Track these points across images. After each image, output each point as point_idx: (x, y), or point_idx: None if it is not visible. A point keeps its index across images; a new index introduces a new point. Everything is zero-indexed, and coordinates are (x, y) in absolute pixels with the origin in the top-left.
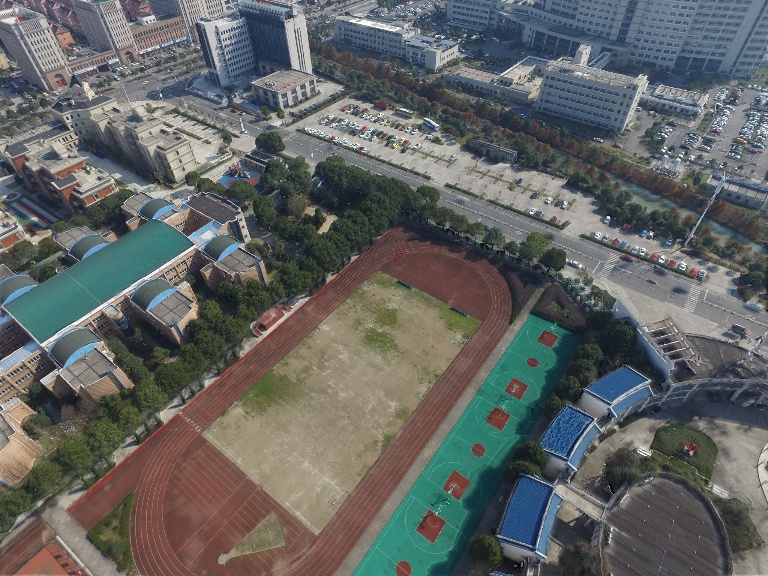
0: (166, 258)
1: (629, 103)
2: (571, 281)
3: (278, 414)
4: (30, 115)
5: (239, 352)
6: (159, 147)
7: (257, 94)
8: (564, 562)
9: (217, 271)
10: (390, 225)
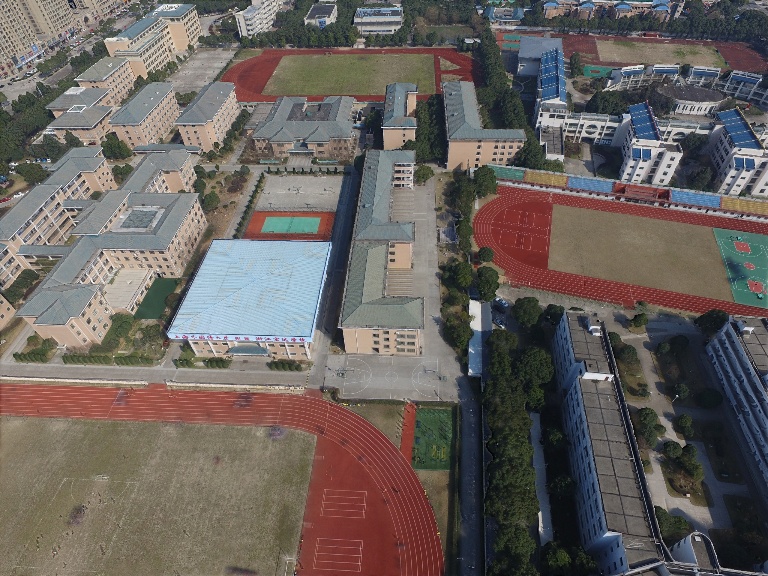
0: (638, 0)
1: None
2: None
3: (621, 47)
4: None
5: (629, 36)
6: None
7: None
8: None
9: (650, 13)
10: (747, 41)
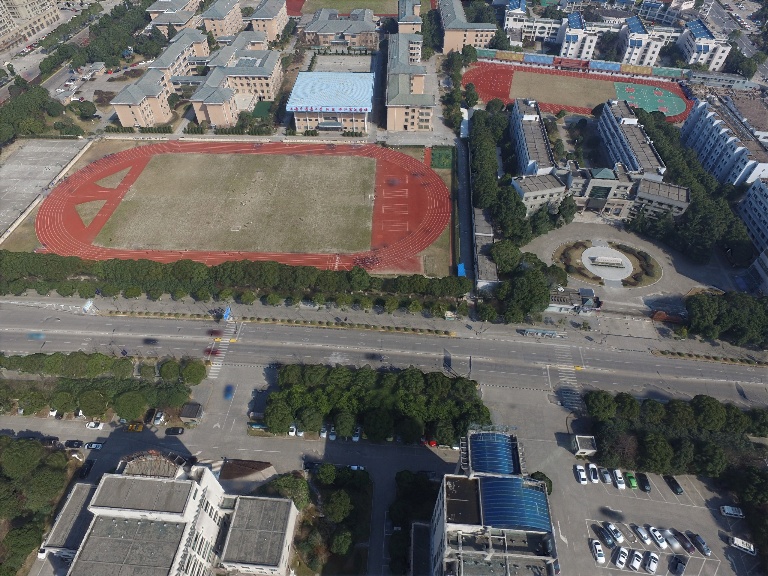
0: None
1: None
2: None
3: None
4: None
5: None
6: None
7: None
8: None
9: None
10: None
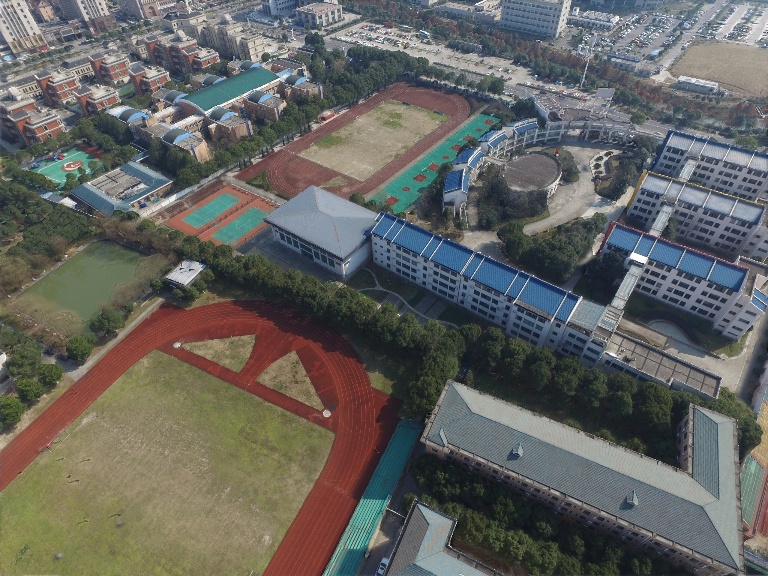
0: (264, 82)
1: (559, 15)
2: (507, 101)
3: (337, 148)
4: (137, 32)
5: (311, 129)
6: (243, 38)
7: (300, 18)
8: (485, 185)
9: (294, 92)
10: (397, 80)
